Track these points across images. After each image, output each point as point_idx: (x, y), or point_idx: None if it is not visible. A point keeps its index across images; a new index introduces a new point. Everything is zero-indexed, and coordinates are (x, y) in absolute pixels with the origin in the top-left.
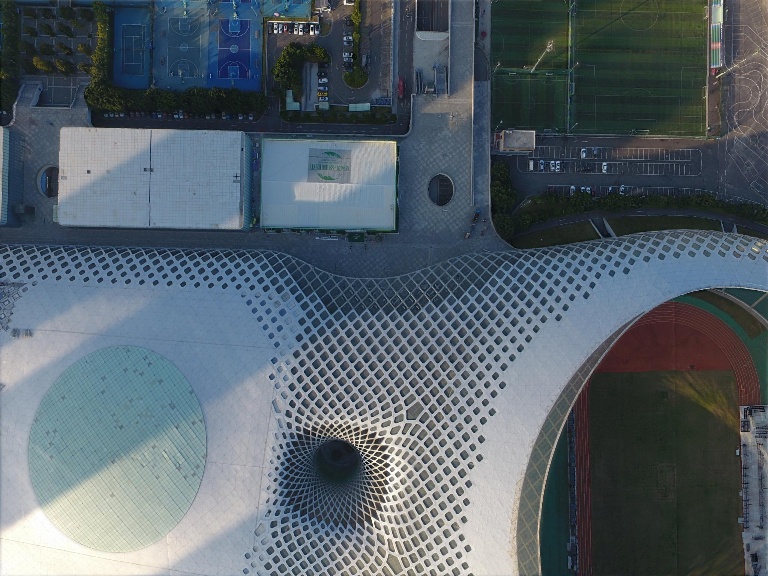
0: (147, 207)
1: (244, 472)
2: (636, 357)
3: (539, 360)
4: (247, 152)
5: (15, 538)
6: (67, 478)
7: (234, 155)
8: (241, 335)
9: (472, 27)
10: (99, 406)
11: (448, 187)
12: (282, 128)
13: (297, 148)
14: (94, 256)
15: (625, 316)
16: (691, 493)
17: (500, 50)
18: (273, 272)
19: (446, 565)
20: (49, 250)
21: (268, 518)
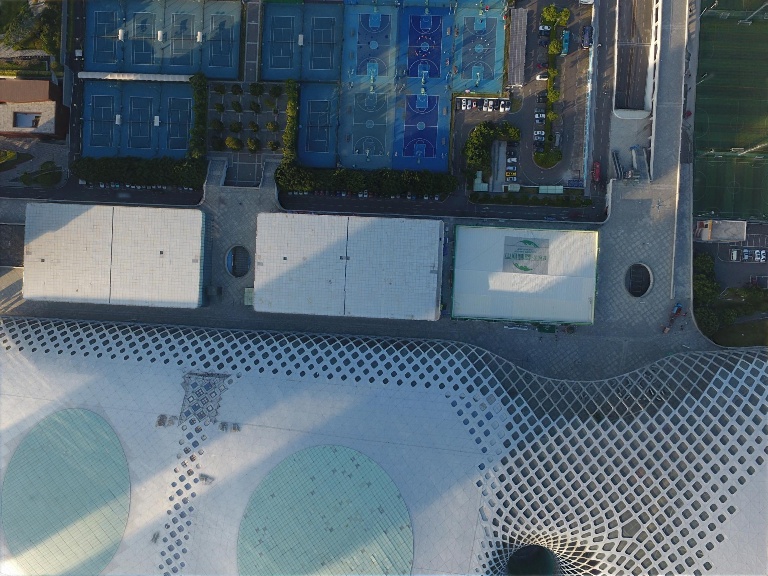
0: (342, 296)
1: None
2: None
3: None
4: (443, 240)
5: None
6: None
7: (432, 245)
8: (447, 438)
9: (680, 108)
10: (309, 507)
11: (641, 275)
12: (468, 209)
13: (492, 236)
14: (292, 346)
15: None
16: None
17: (704, 130)
18: (475, 371)
19: None
20: (247, 338)
21: None
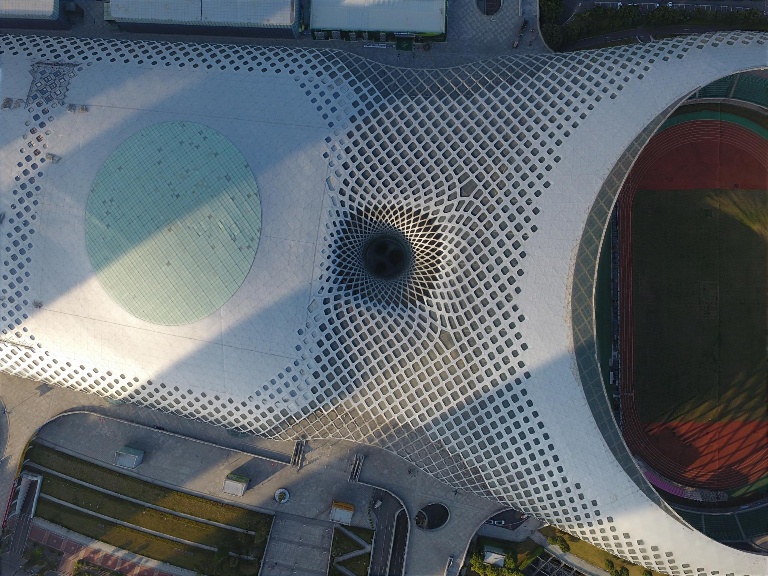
0: (199, 1)
1: (298, 248)
2: (681, 175)
3: (594, 134)
4: None
5: (70, 311)
6: (123, 246)
7: None
8: (295, 115)
9: None
10: (156, 175)
11: (495, 2)
12: None
13: None
14: (147, 44)
15: (681, 91)
16: (733, 311)
17: None
18: (326, 61)
19: (499, 337)
20: (102, 39)
21: (321, 295)
